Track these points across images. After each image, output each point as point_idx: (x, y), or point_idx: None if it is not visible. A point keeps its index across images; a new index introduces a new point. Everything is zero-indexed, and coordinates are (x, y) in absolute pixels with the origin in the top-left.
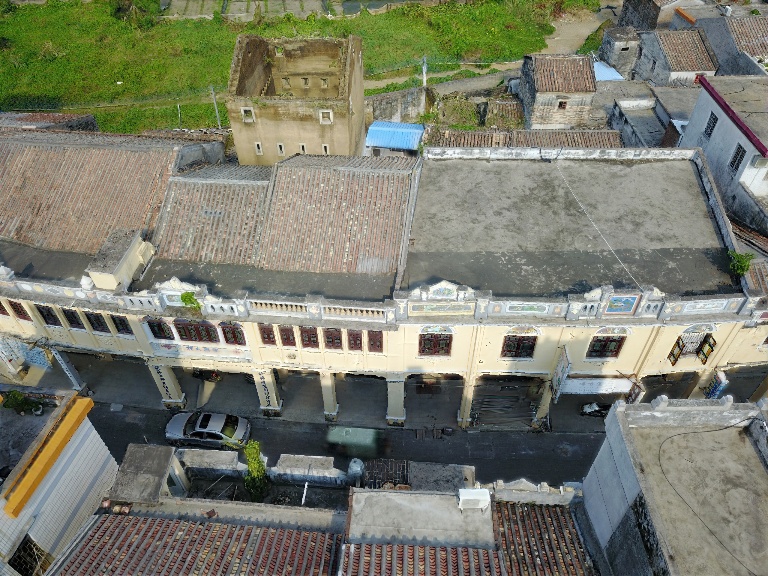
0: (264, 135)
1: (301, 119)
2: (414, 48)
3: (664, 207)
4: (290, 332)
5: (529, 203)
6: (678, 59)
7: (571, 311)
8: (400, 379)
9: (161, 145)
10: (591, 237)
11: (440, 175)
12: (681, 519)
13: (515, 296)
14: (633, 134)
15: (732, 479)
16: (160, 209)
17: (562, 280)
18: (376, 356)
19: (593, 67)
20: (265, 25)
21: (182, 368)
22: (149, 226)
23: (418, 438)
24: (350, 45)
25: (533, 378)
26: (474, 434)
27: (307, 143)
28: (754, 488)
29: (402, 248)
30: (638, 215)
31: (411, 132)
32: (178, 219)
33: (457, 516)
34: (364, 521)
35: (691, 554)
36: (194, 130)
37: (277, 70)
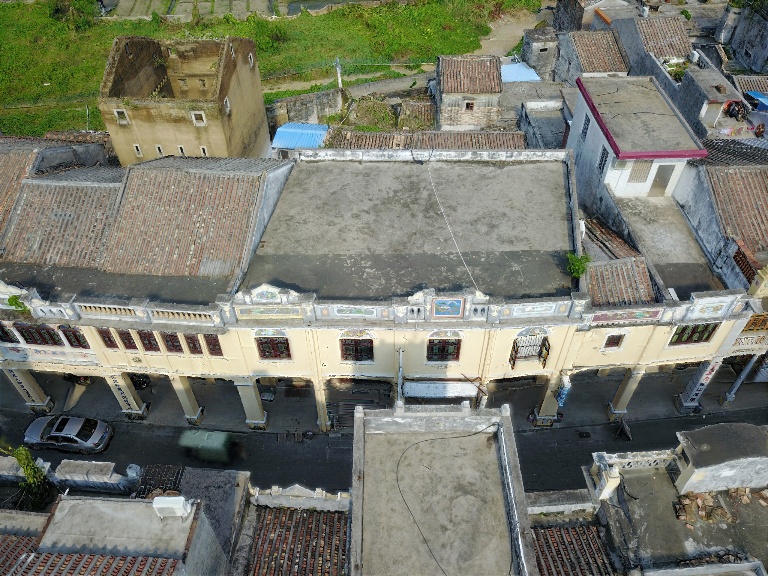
0: (141, 137)
1: (175, 121)
2: (346, 49)
3: (524, 209)
4: (129, 335)
5: (390, 205)
6: (590, 60)
7: (397, 314)
8: (248, 383)
9: (30, 147)
10: (442, 239)
11: (308, 177)
12: (399, 527)
13: (350, 299)
14: (534, 135)
15: (464, 486)
16: (10, 211)
17: (402, 283)
18: (218, 359)
19: (500, 68)
20: (203, 26)
21: (56, 371)
22: (0, 229)
23: (279, 442)
24: (226, 46)
25: (380, 381)
26: (335, 438)
27: (185, 145)
28: (483, 495)
29: (245, 251)
30: (495, 217)
31: (319, 133)
32: (27, 222)
33: (156, 524)
34: (60, 529)
35: (396, 563)
36: (100, 132)
37: (173, 71)
